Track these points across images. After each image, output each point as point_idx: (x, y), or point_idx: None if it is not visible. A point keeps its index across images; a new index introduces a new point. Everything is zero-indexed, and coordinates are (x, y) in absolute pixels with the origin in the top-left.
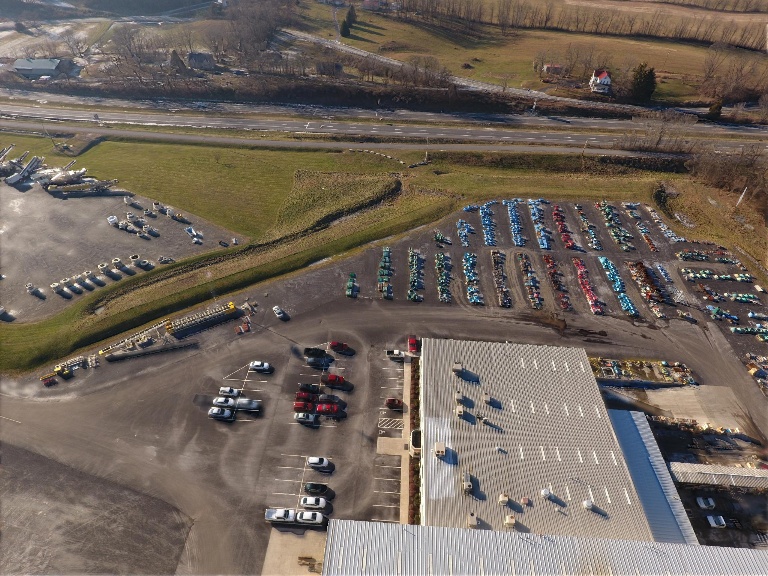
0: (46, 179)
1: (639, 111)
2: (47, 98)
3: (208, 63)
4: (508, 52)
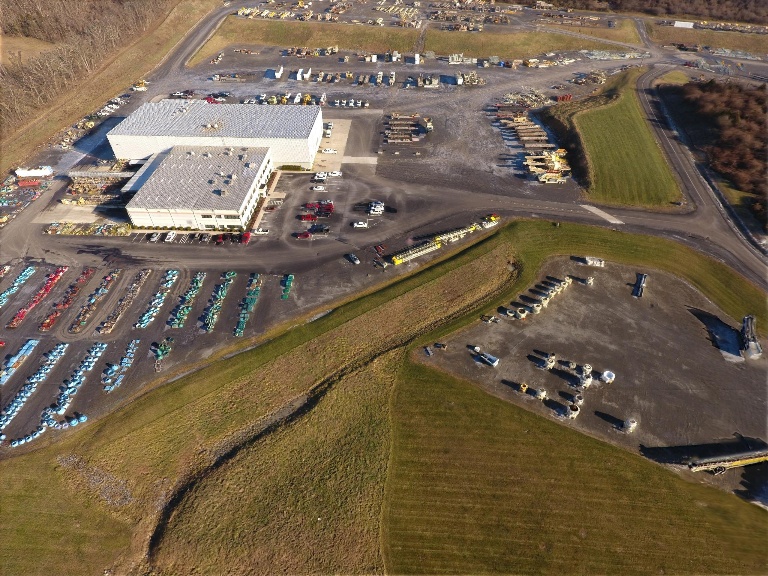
0: None
1: None
2: None
3: None
4: None
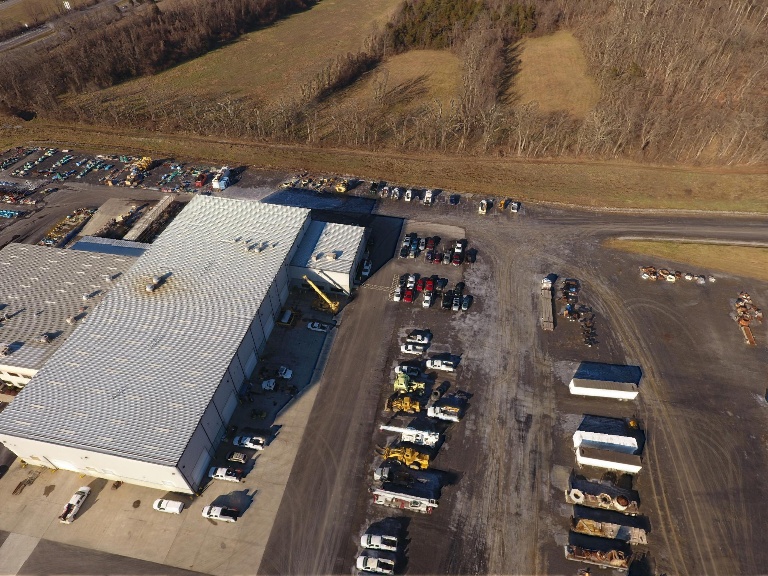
0: None
1: None
2: None
3: None
4: None
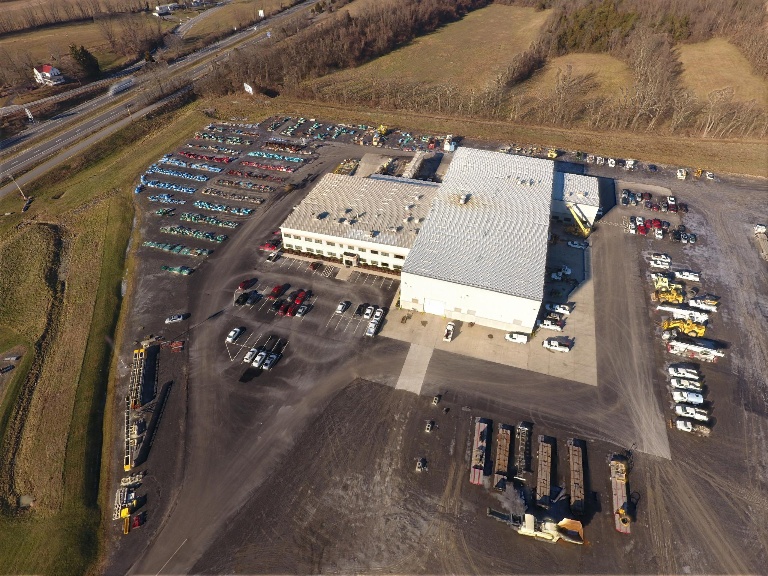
0: None
1: (108, 82)
2: None
3: None
4: None
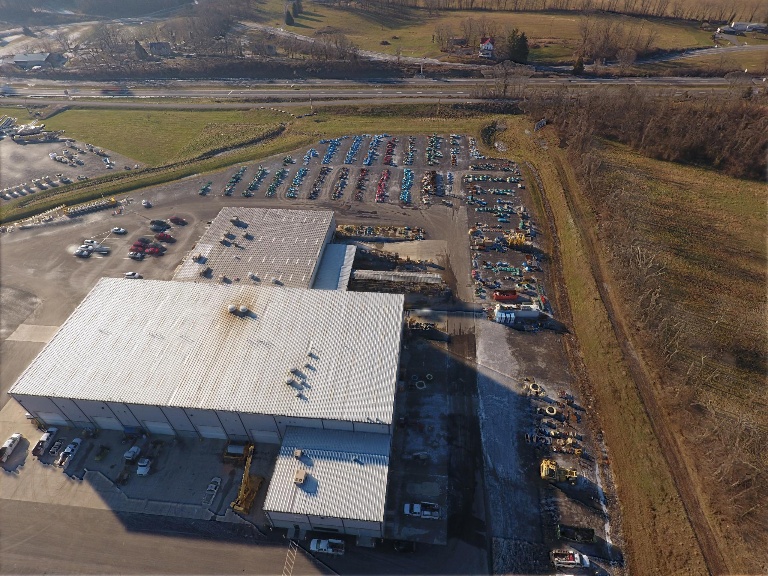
0: (13, 132)
1: None
2: (35, 82)
3: (165, 50)
4: (425, 30)
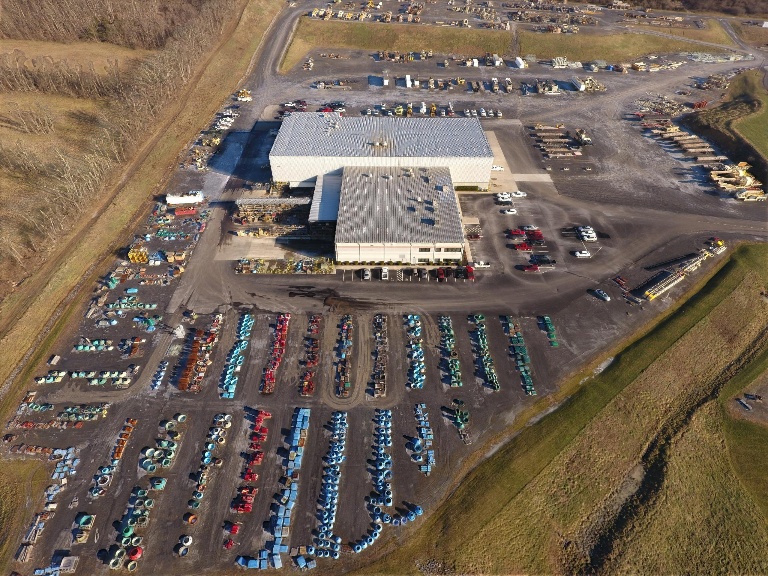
0: None
1: None
2: None
3: None
4: None
